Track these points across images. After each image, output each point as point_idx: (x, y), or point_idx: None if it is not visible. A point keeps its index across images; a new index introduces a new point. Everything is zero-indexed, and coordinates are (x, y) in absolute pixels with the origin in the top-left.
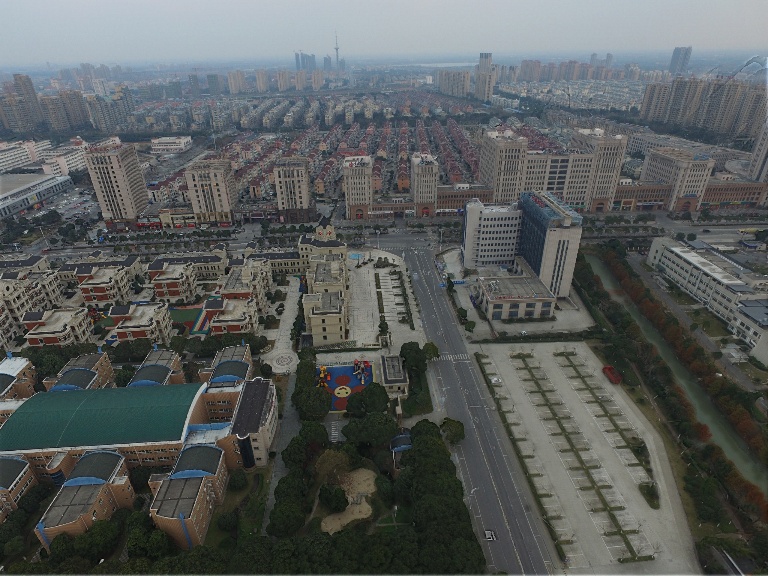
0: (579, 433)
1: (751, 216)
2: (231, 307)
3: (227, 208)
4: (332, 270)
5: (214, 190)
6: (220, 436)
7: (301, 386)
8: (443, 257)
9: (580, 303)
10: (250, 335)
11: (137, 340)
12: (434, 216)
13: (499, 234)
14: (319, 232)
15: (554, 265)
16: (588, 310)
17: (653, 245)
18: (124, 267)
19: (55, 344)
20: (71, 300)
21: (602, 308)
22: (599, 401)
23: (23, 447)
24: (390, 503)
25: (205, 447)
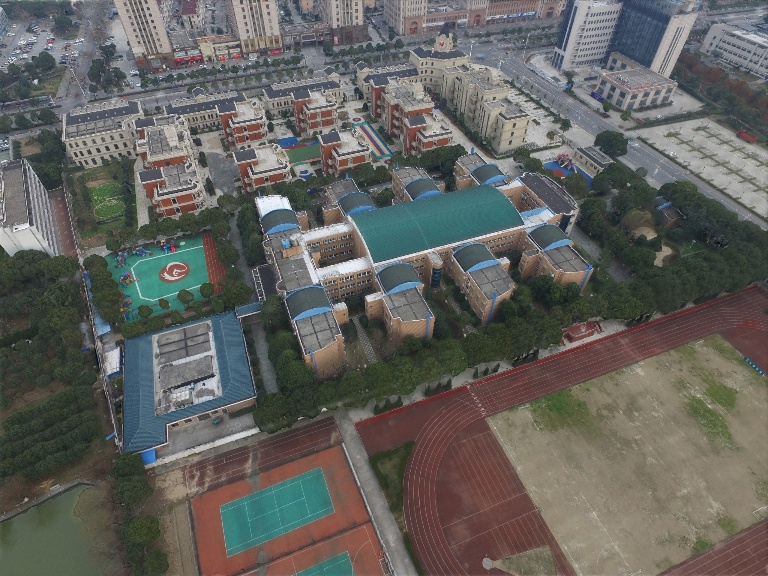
0: (756, 178)
1: (745, 3)
2: (430, 122)
3: (277, 30)
4: (492, 77)
5: (263, 7)
6: (544, 218)
7: None
8: (532, 63)
9: (678, 89)
10: (461, 146)
11: (364, 165)
12: (484, 25)
13: (599, 30)
14: (441, 42)
15: (666, 54)
16: (689, 94)
17: (711, 32)
18: (254, 101)
19: (281, 181)
20: (205, 147)
21: (704, 90)
22: (751, 156)
23: (401, 254)
24: (681, 241)
25: (549, 225)
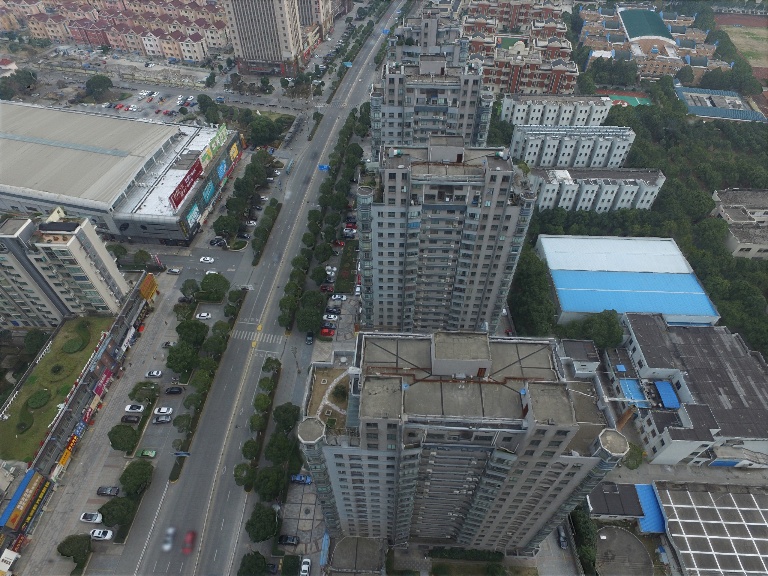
0: None
1: None
2: None
3: (330, 9)
4: None
5: None
6: None
7: (612, 5)
8: None
9: None
10: None
11: None
12: None
13: None
14: None
15: None
16: None
17: None
18: None
19: None
20: None
21: None
22: None
23: (672, 37)
24: None
25: None
